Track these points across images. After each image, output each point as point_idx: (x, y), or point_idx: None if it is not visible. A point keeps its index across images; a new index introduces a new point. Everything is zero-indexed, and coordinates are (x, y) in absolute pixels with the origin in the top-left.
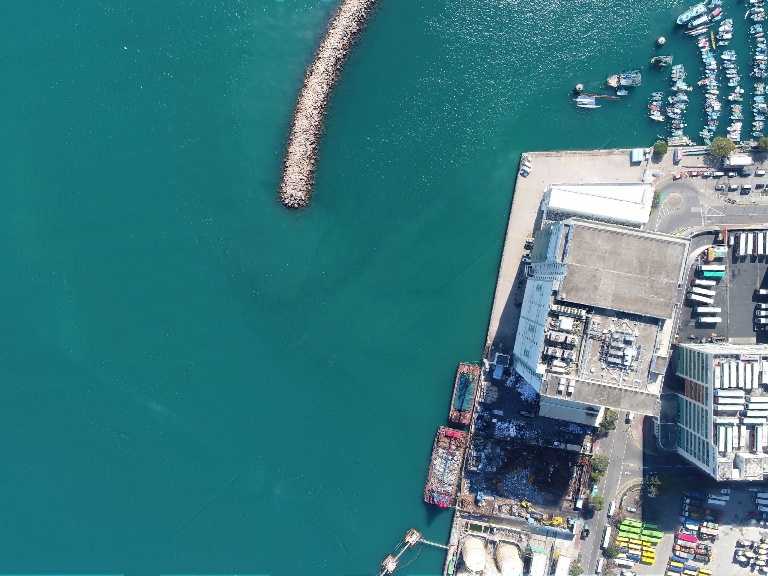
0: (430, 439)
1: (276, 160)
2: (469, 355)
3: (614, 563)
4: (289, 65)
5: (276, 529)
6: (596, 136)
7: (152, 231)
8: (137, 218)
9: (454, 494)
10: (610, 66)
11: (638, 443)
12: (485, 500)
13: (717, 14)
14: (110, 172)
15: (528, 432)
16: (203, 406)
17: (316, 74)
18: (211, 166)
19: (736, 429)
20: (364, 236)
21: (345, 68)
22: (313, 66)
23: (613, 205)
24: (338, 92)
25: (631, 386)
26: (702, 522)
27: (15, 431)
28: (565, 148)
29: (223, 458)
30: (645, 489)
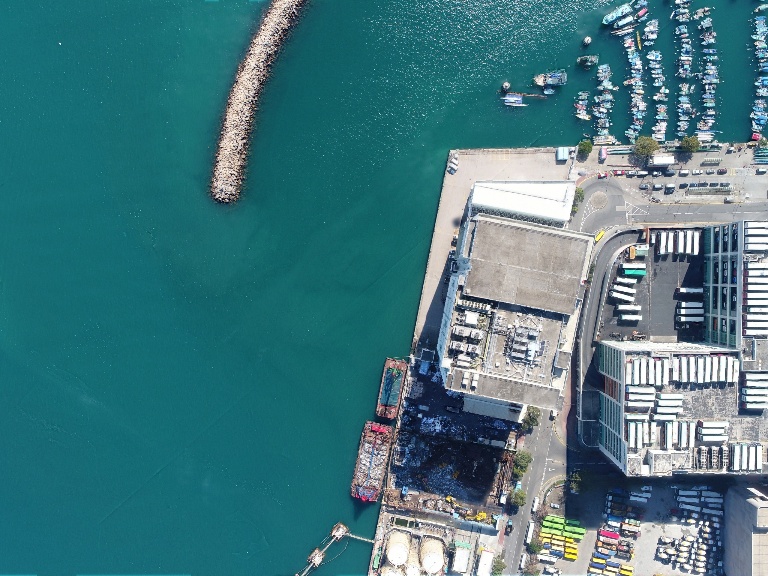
0: (357, 434)
1: (208, 155)
2: (396, 350)
3: (536, 559)
4: (221, 61)
5: (205, 522)
6: (523, 134)
7: (79, 224)
8: (64, 210)
9: (380, 489)
10: (537, 65)
11: (562, 440)
12: (410, 495)
13: (643, 15)
14: (38, 165)
15: (453, 428)
16: (128, 398)
17: (247, 70)
18: (139, 160)
19: (647, 425)
20: (294, 231)
21: (277, 64)
22: (245, 62)
23: (535, 203)
24: (270, 88)
25: (535, 381)
26: (624, 519)
27: None
28: (492, 146)
29: (148, 450)
30: (569, 485)
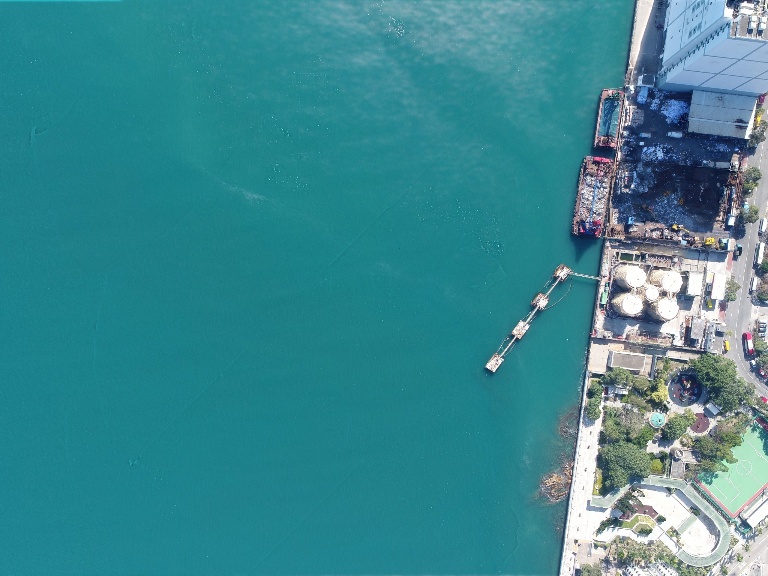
0: (575, 172)
1: None
2: (611, 83)
3: None
4: None
5: (421, 277)
6: None
7: None
8: None
9: (603, 225)
10: None
11: None
12: (636, 226)
13: None
14: None
15: (675, 155)
16: (353, 133)
17: None
18: None
19: None
20: None
21: None
22: None
23: None
24: None
25: None
26: None
27: (146, 196)
28: None
29: (376, 186)
30: None
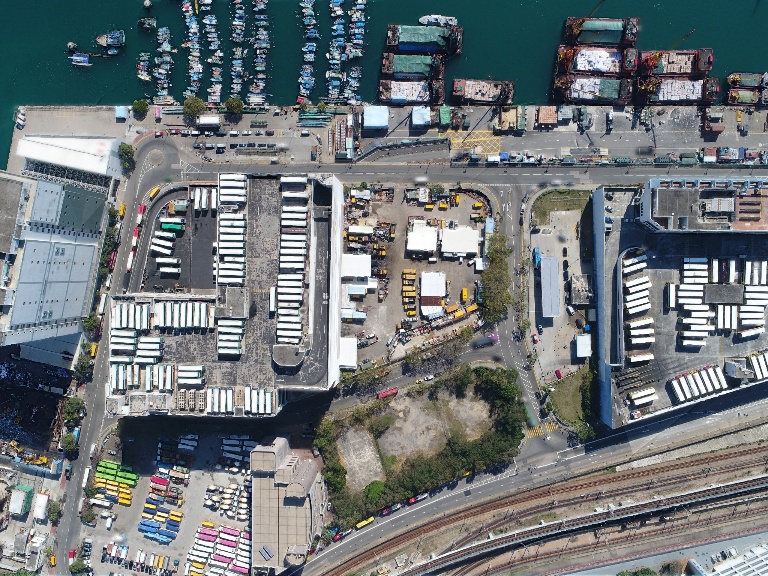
0: None
1: None
2: None
3: (87, 502)
4: None
5: None
6: (88, 93)
7: None
8: None
9: None
10: (101, 26)
11: None
12: None
13: None
14: None
15: (19, 375)
16: None
17: None
18: None
19: (130, 368)
20: None
21: None
22: None
23: (74, 156)
24: None
25: None
26: (173, 466)
27: None
28: (61, 103)
29: None
30: None
